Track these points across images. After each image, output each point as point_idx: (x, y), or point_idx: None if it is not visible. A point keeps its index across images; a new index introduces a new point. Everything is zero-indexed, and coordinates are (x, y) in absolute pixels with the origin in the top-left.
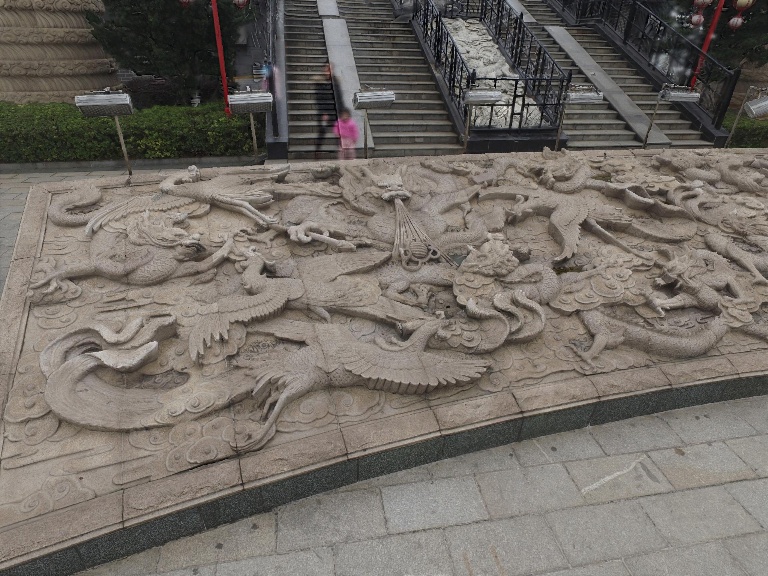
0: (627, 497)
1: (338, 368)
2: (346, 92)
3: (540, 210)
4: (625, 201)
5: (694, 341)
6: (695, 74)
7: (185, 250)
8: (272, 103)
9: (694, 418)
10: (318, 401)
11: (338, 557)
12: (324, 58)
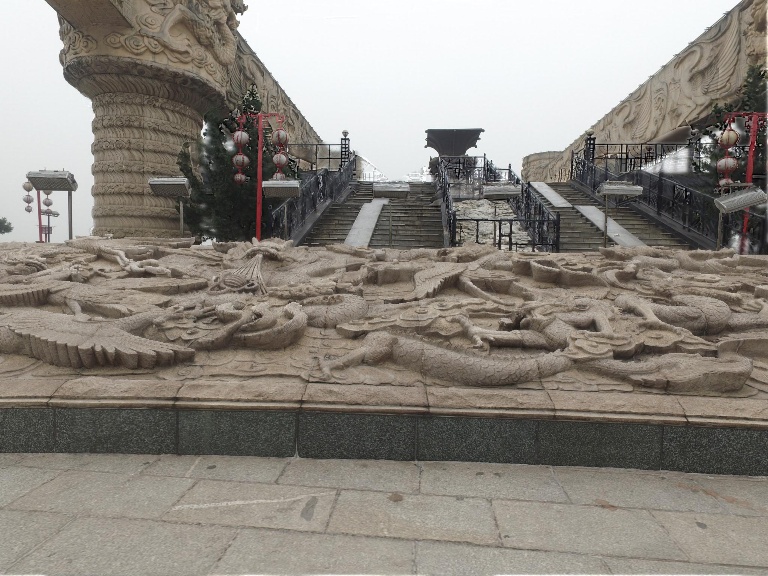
0: (230, 523)
1: (5, 326)
2: (354, 243)
3: None
4: None
5: (492, 362)
6: (728, 226)
7: (22, 266)
8: (189, 187)
9: (473, 472)
10: None
11: None
12: (351, 225)
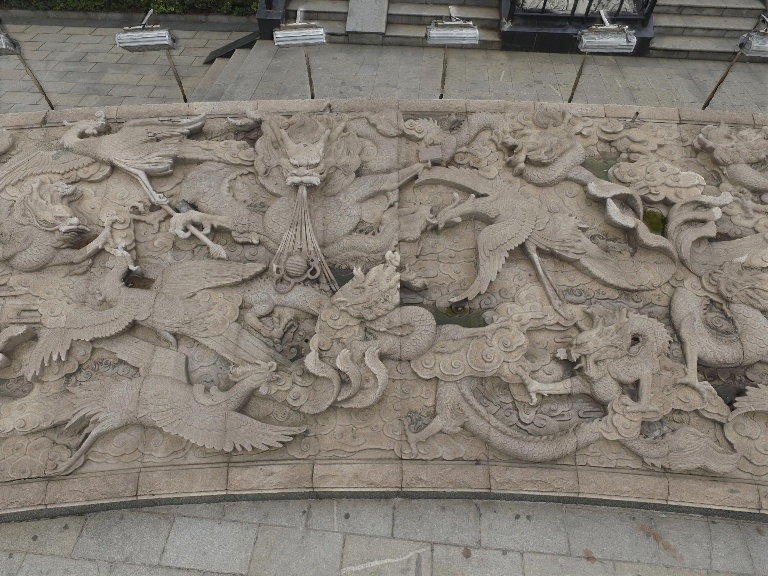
0: None
1: (147, 414)
2: None
3: (478, 216)
4: (604, 212)
5: (542, 449)
6: None
7: (62, 237)
8: (173, 42)
9: (513, 516)
10: (131, 436)
11: (112, 574)
12: None
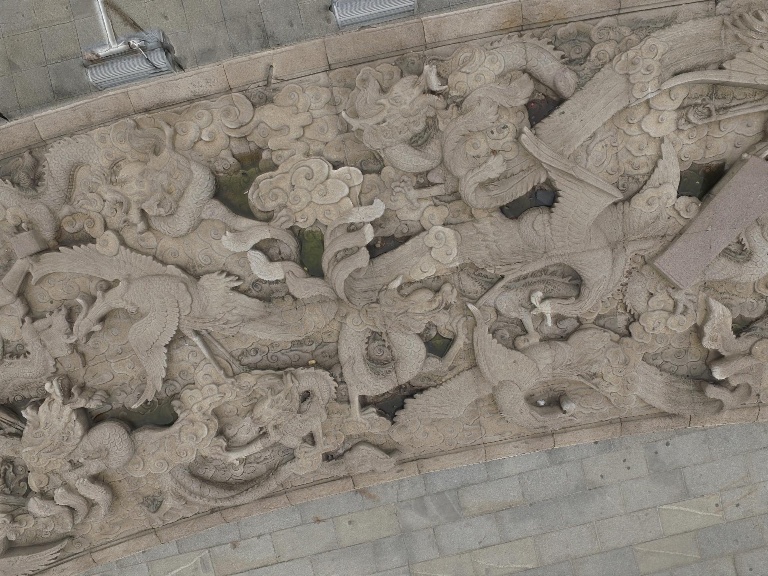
0: None
1: None
2: None
3: None
4: None
5: (250, 497)
6: None
7: None
8: None
9: None
10: None
11: None
12: None
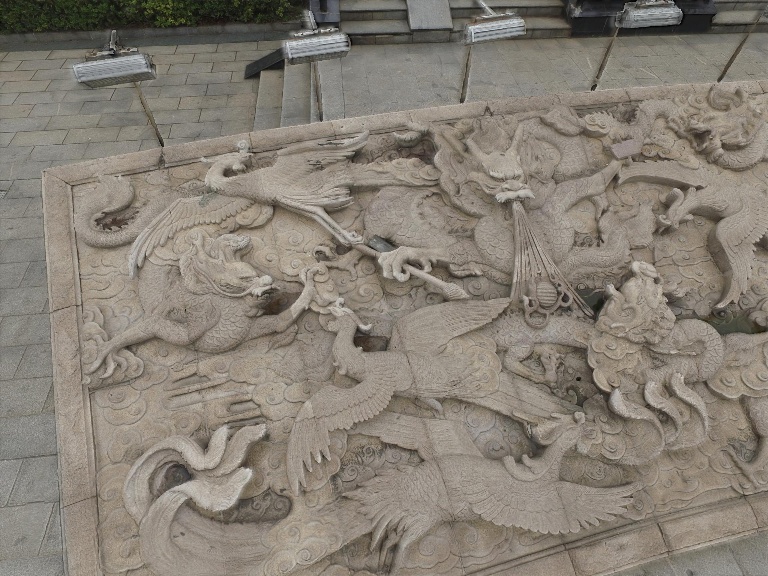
0: None
1: (464, 508)
2: None
3: (700, 210)
4: None
5: None
6: None
7: (257, 302)
8: None
9: None
10: (439, 538)
11: None
12: None
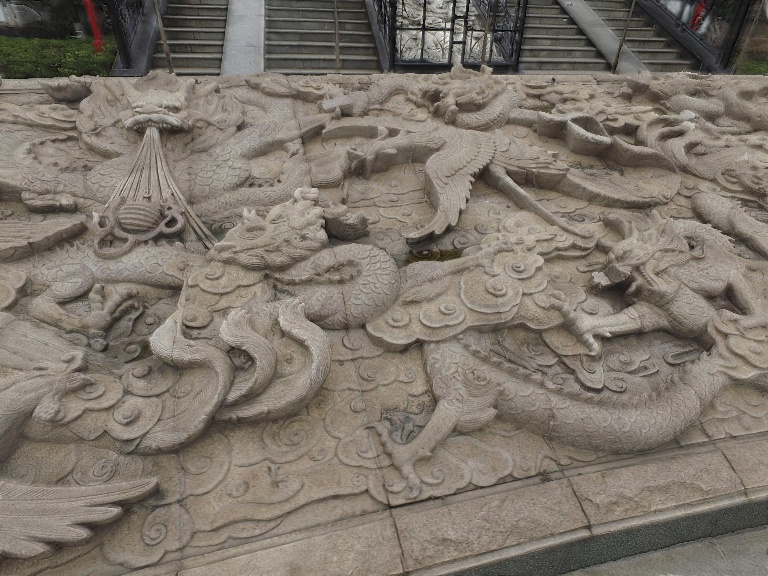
0: None
1: None
2: (243, 18)
3: (417, 153)
4: (567, 142)
5: (650, 415)
6: None
7: None
8: None
9: None
10: None
11: None
12: None
